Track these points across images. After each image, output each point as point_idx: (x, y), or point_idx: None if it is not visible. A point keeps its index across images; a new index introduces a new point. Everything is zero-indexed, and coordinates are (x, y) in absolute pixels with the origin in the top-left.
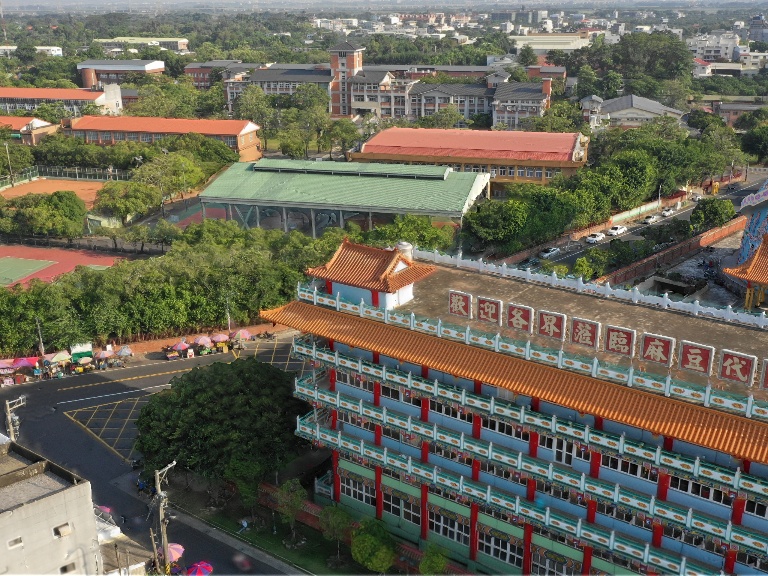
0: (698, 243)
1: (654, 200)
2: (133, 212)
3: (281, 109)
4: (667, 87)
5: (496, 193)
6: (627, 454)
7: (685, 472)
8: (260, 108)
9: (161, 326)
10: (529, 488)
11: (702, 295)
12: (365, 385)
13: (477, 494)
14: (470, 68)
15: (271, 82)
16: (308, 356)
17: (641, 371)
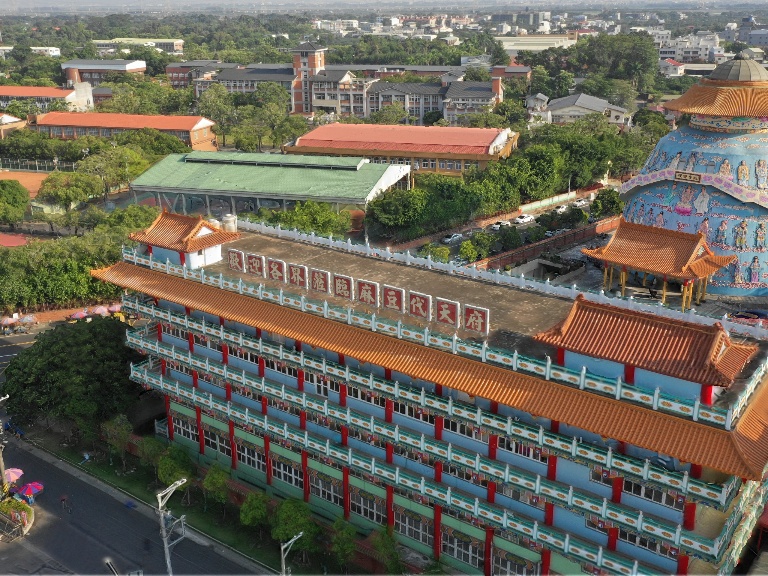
0: (594, 230)
1: None
2: (78, 201)
3: (238, 106)
4: (616, 86)
5: None
6: (351, 381)
7: (389, 394)
8: (218, 105)
9: (64, 297)
10: (301, 418)
11: (577, 276)
12: (183, 335)
13: (258, 423)
14: (439, 68)
15: (237, 81)
16: (133, 309)
17: (365, 313)
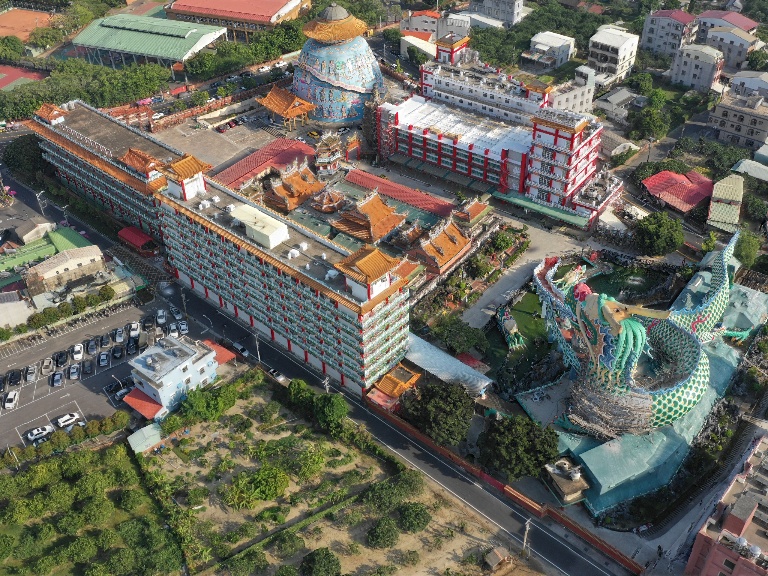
0: None
1: None
2: None
3: None
4: None
5: (242, 35)
6: None
7: (97, 170)
8: None
9: None
10: None
11: None
12: None
13: (75, 175)
14: None
15: None
16: (39, 136)
17: None
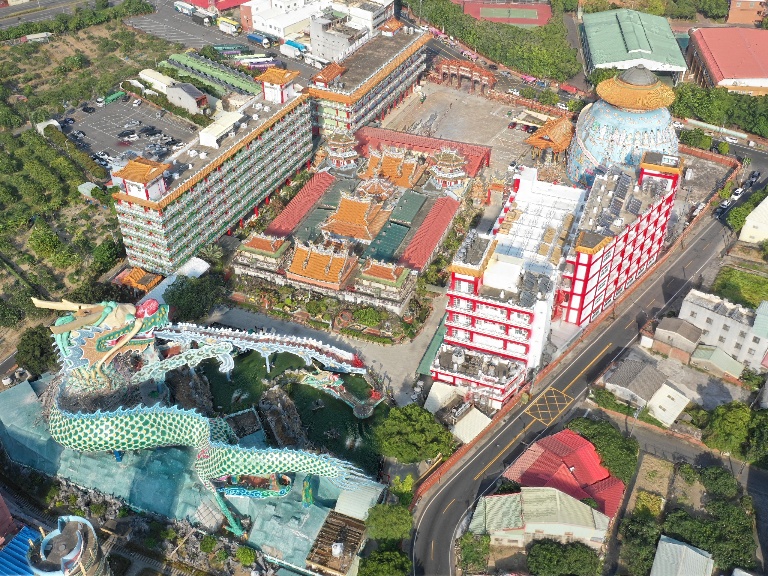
0: None
1: (762, 138)
2: None
3: None
4: None
5: None
6: None
7: None
8: None
9: None
10: None
11: None
12: None
13: None
14: None
15: None
16: None
17: None
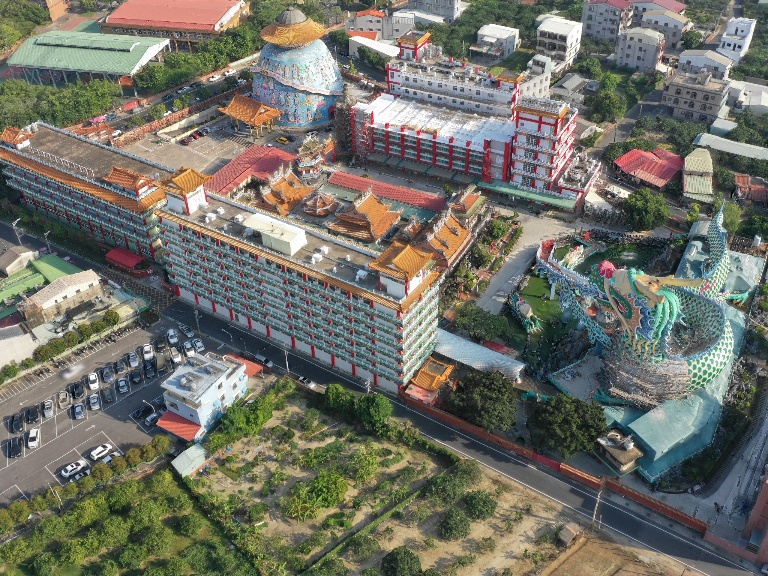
0: None
1: None
2: None
3: None
4: None
5: (183, 45)
6: (67, 188)
7: (76, 192)
8: None
9: None
10: None
11: None
12: None
13: (48, 200)
14: None
15: None
16: (2, 162)
17: None
